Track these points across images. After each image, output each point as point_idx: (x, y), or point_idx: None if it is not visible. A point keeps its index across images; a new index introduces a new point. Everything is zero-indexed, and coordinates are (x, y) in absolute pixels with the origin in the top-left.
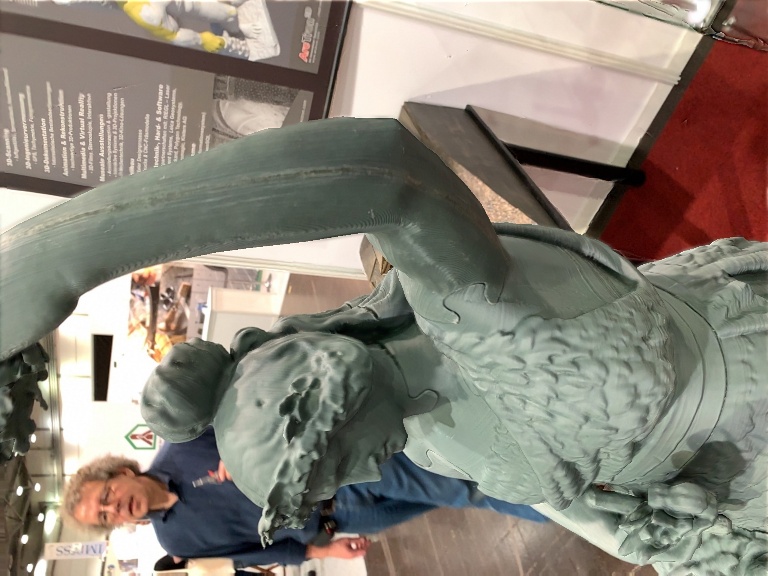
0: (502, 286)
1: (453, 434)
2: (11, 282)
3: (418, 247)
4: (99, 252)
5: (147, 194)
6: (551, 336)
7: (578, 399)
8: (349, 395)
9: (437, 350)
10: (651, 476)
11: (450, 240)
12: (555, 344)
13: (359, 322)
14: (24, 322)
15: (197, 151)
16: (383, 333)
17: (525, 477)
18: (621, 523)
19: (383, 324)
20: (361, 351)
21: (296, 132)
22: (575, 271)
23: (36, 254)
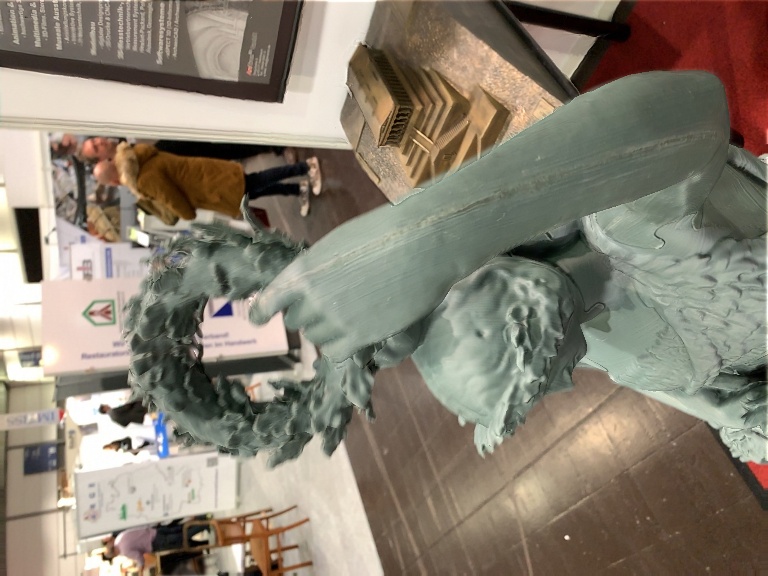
0: (702, 211)
1: (605, 338)
2: (409, 276)
3: (685, 193)
4: (492, 241)
5: (529, 178)
6: (744, 256)
7: (757, 310)
8: (562, 321)
9: (607, 266)
10: (763, 359)
11: (710, 183)
12: (747, 264)
13: (534, 243)
14: (412, 311)
15: (166, 12)
16: (551, 251)
17: (674, 372)
18: (723, 397)
19: (555, 243)
20: (560, 277)
21: (640, 97)
22: (738, 185)
23: (435, 247)
